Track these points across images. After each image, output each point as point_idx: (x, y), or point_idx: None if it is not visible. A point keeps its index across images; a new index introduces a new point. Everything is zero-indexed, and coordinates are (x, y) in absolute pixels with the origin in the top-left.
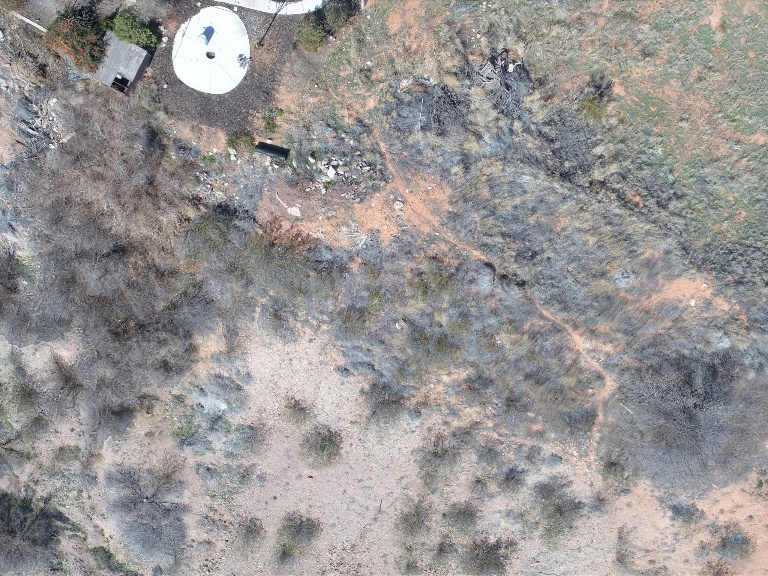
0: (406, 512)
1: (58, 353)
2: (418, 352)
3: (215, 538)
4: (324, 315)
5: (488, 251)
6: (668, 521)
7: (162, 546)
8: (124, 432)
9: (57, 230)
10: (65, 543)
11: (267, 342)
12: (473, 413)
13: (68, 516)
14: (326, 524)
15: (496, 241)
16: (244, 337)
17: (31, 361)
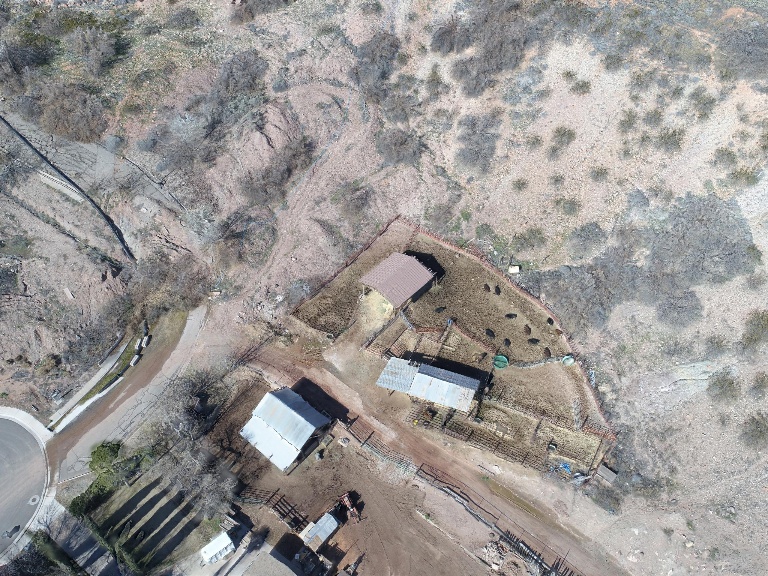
0: (623, 120)
1: (459, 60)
2: (628, 37)
3: (511, 153)
4: (585, 34)
5: (653, 7)
6: (759, 96)
7: (478, 163)
8: (476, 99)
9: (488, 0)
10: (424, 157)
11: (558, 48)
12: (654, 65)
13: (429, 146)
14: (578, 134)
15: (656, 3)
16: (547, 48)
17: (442, 69)
